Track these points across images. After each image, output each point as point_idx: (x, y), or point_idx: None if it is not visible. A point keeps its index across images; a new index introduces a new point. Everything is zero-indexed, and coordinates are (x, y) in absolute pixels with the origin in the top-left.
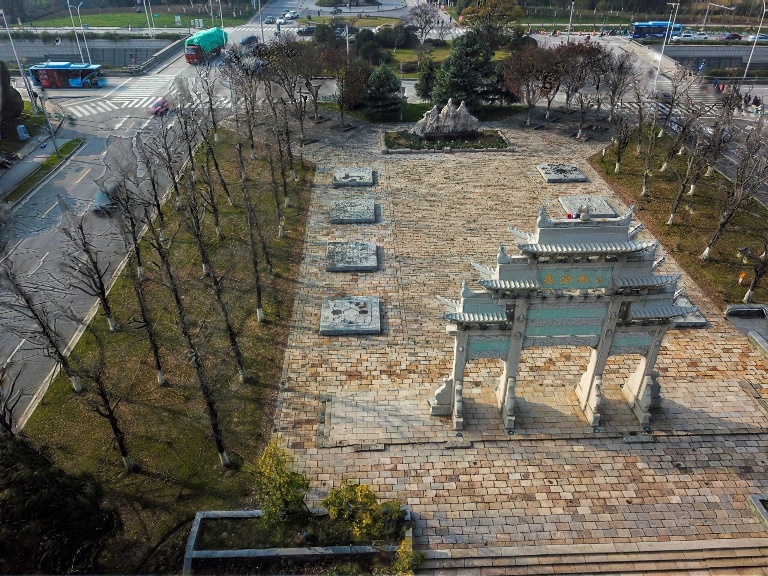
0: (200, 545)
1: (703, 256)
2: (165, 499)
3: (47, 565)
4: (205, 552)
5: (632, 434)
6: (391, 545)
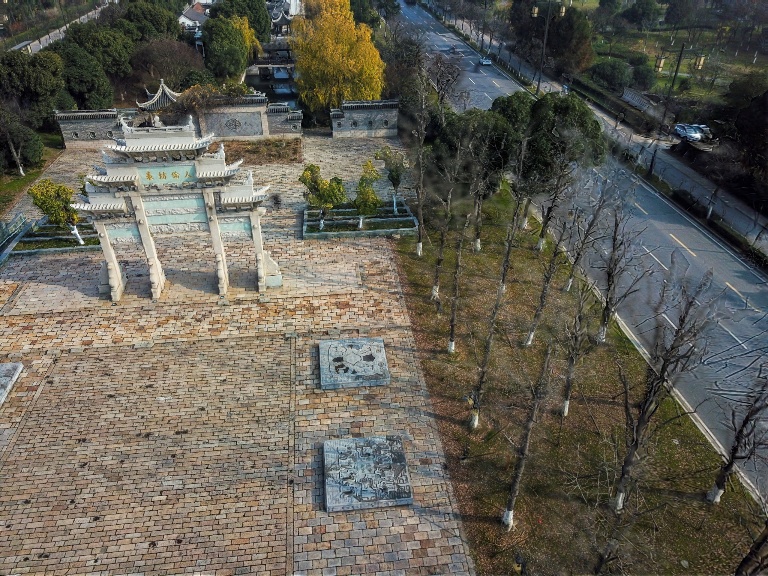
0: (411, 221)
1: None
2: None
3: None
4: (406, 218)
5: (140, 275)
6: (314, 223)
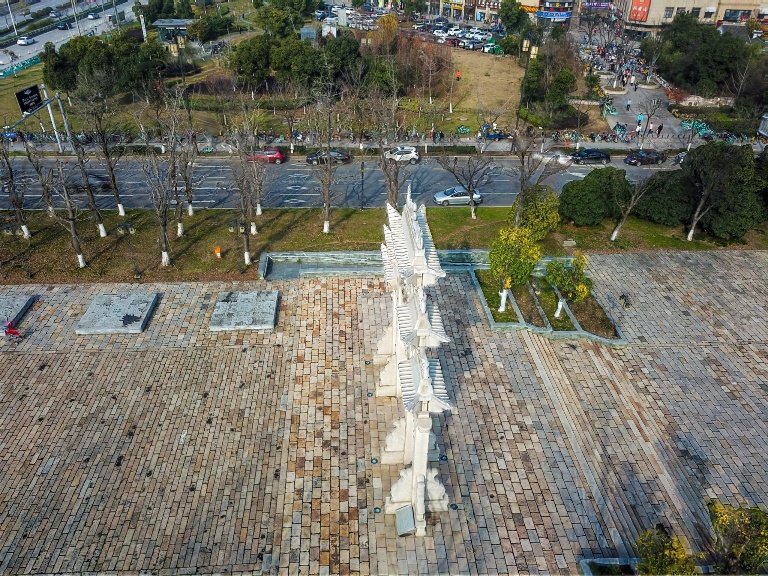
0: None
1: (166, 262)
2: None
3: None
4: None
5: None
6: None
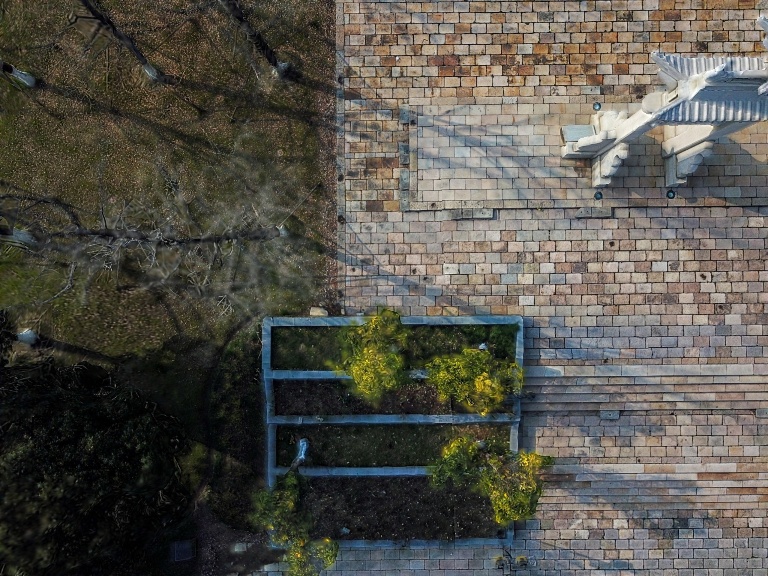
0: (278, 362)
1: None
2: (218, 286)
3: (134, 514)
4: (286, 373)
5: None
6: None
